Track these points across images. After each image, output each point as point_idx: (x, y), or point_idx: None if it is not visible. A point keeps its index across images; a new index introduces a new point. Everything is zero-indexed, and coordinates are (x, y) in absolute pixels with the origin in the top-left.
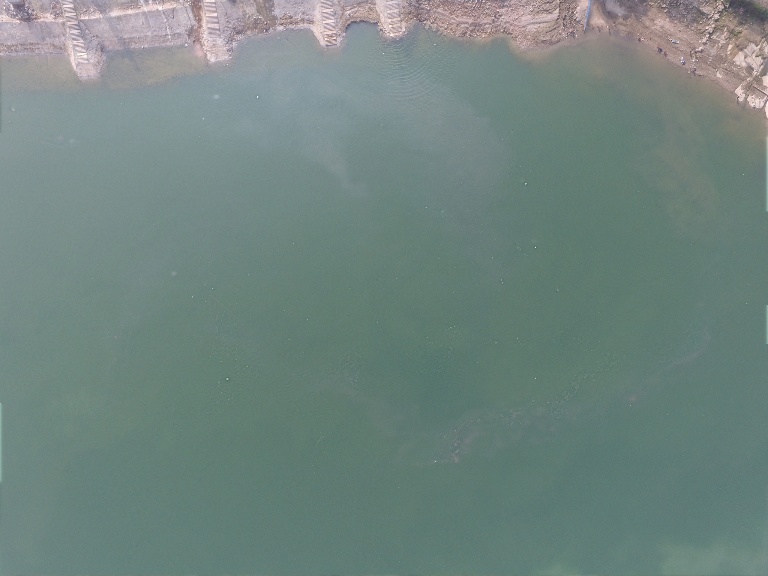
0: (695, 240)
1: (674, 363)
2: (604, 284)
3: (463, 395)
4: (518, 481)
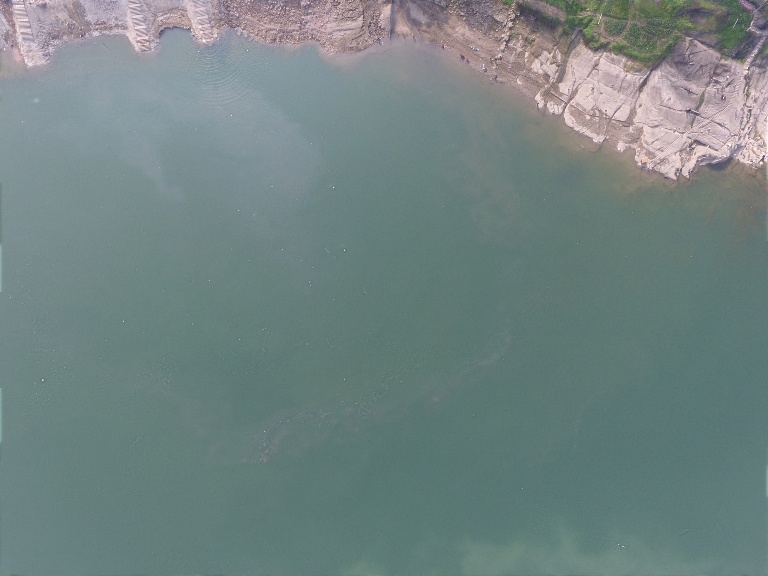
0: (497, 243)
1: (478, 364)
2: (410, 286)
3: (272, 396)
4: (331, 481)
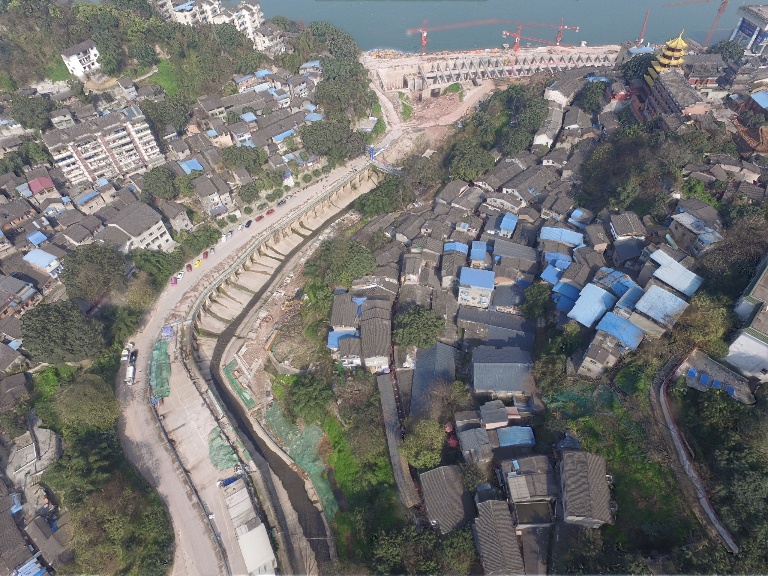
0: None
1: (324, 7)
2: None
3: None
4: None
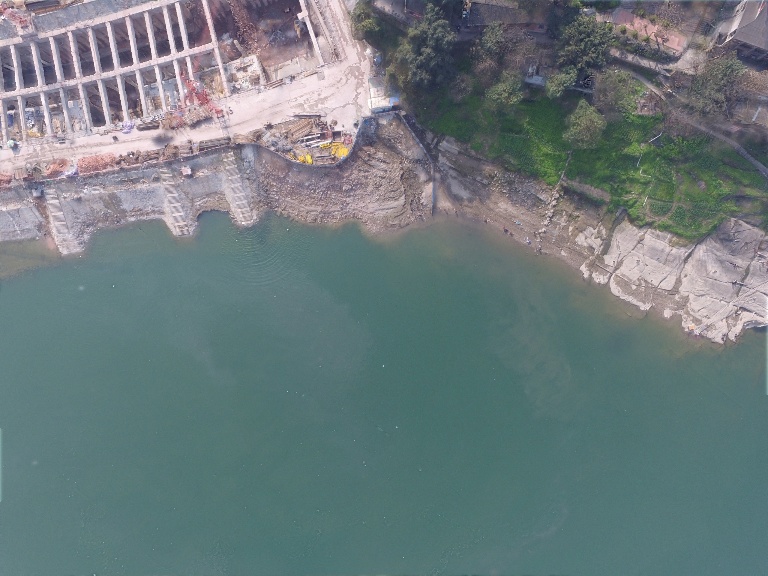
0: (550, 415)
1: (537, 536)
2: (465, 461)
3: None
4: None
